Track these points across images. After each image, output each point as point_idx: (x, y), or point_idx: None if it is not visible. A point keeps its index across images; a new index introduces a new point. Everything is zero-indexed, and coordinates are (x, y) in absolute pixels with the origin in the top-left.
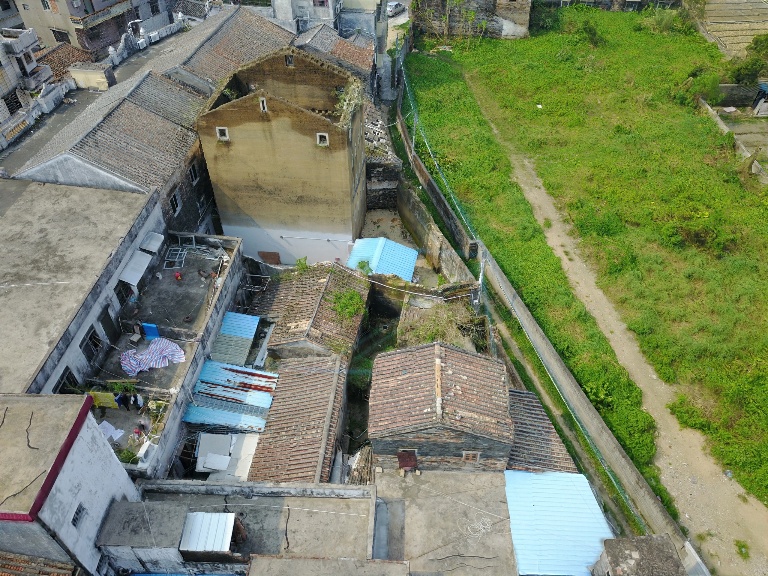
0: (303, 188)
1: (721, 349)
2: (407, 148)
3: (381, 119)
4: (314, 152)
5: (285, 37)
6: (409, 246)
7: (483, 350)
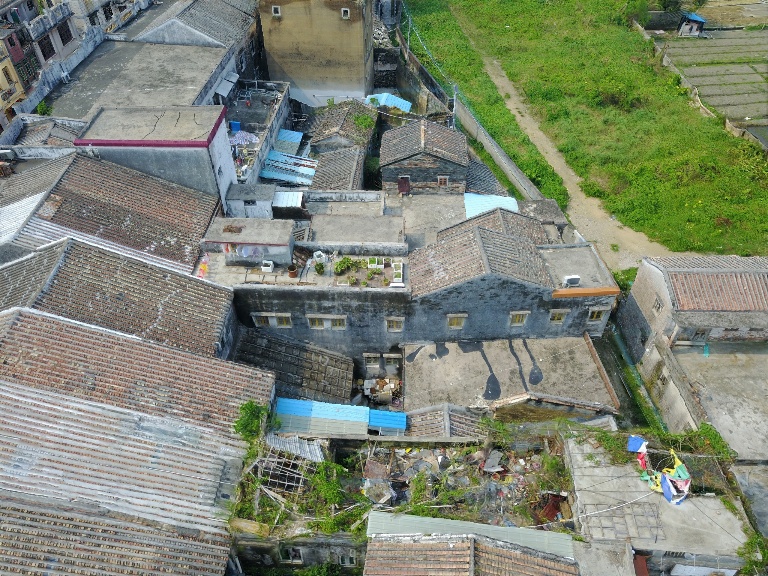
0: (331, 54)
1: (619, 157)
2: (404, 50)
3: None
4: (339, 24)
5: None
6: None
7: None
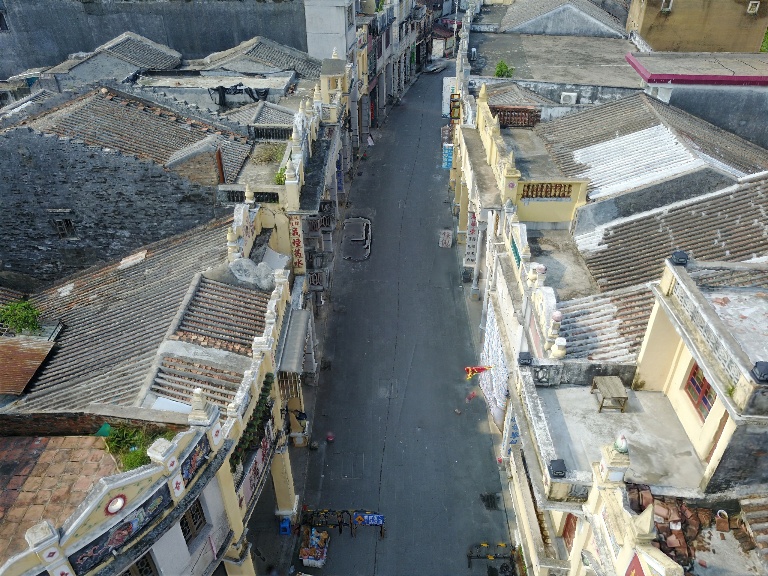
0: None
1: None
2: None
3: None
4: (741, 19)
5: None
6: None
7: None
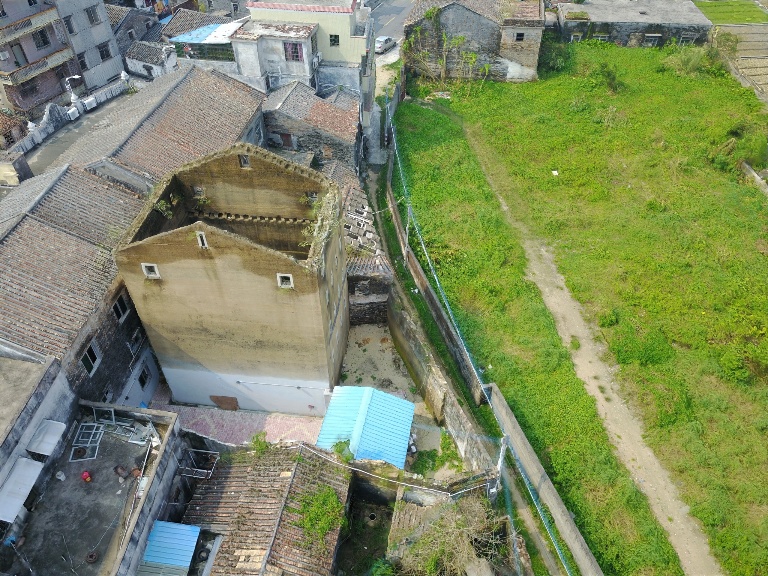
0: (262, 332)
1: None
2: (399, 236)
3: (367, 204)
4: (274, 294)
5: (250, 103)
6: (403, 382)
7: (504, 564)
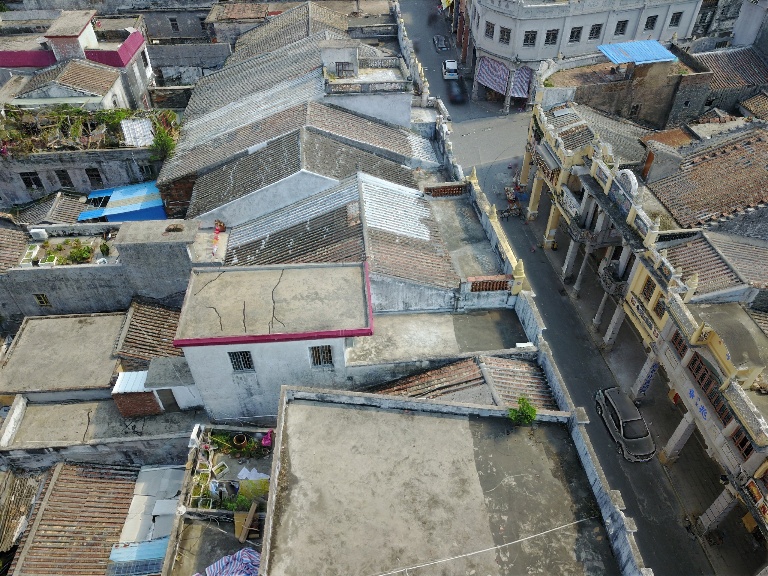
0: None
1: None
2: None
3: None
4: None
5: None
6: None
7: None
